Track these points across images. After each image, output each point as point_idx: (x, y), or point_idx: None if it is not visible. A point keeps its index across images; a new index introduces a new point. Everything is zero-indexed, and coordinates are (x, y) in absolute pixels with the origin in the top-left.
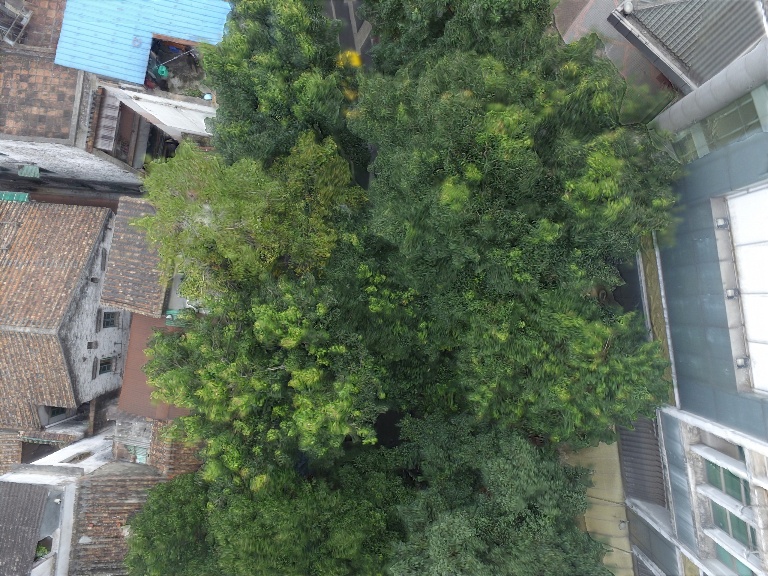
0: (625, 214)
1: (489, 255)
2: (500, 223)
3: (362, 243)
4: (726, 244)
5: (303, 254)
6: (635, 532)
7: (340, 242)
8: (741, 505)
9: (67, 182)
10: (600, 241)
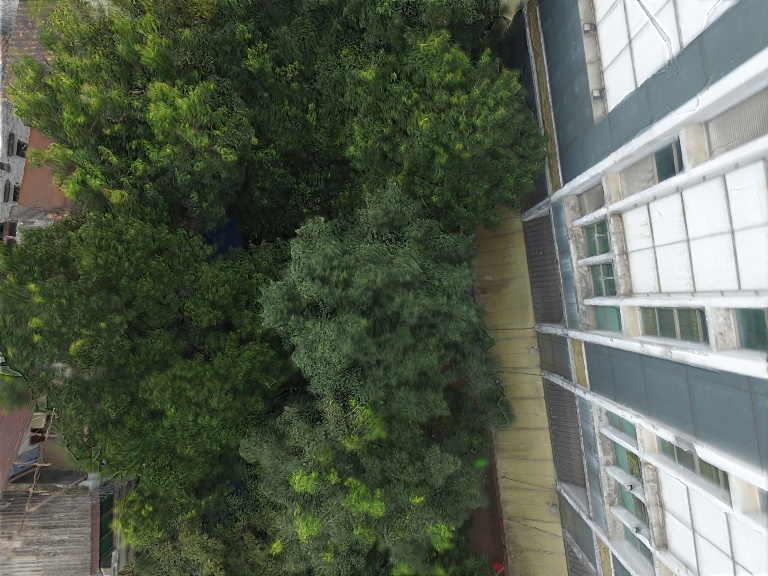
0: None
1: None
2: None
3: (242, 7)
4: None
5: (182, 14)
6: (544, 356)
7: (222, 9)
8: None
9: None
10: None
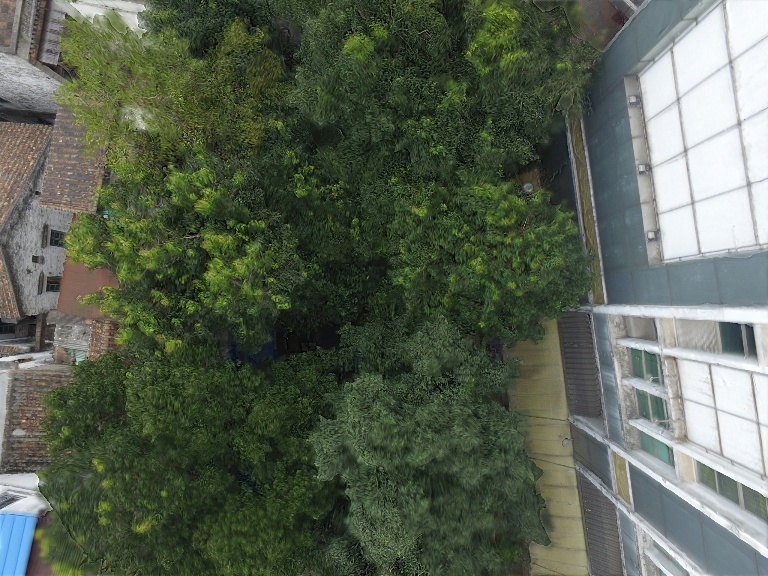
0: (526, 71)
1: (404, 127)
2: (413, 94)
3: (289, 131)
4: (639, 122)
5: (230, 140)
6: (577, 448)
7: (268, 132)
8: (658, 385)
9: (23, 115)
10: (509, 108)
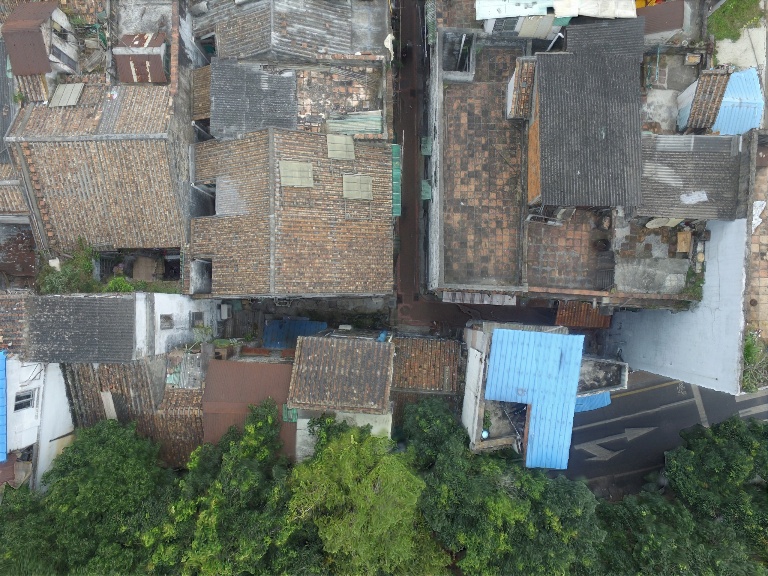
0: None
1: None
2: None
3: None
4: None
5: None
6: None
7: None
8: None
9: None
10: None
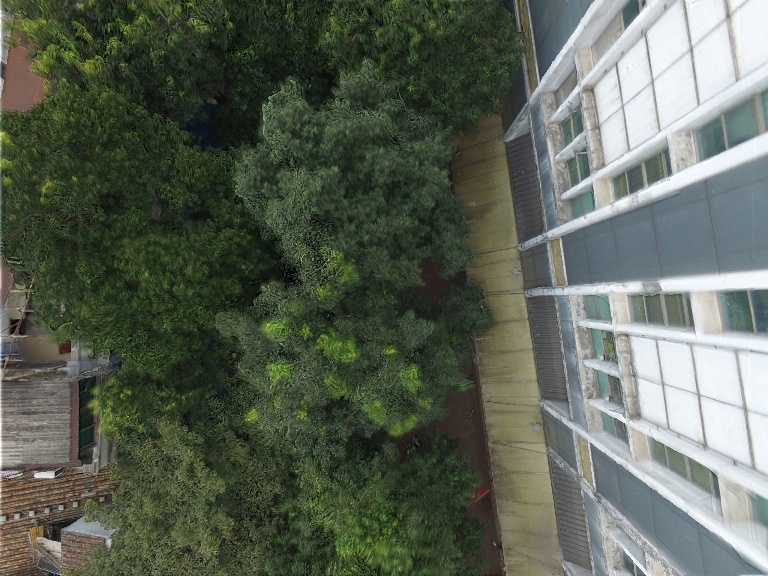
0: None
1: None
2: None
3: None
4: None
5: None
6: (526, 275)
7: None
8: None
9: None
10: None
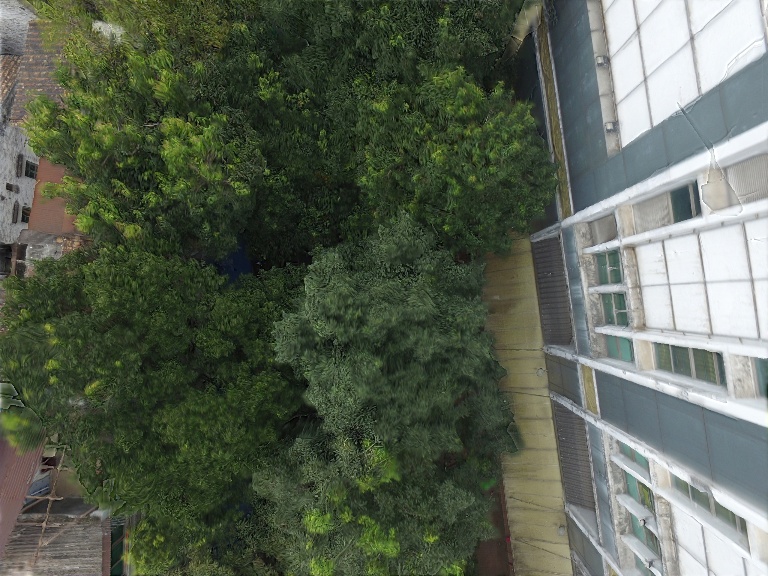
0: None
1: (363, 18)
2: None
3: (254, 36)
4: (597, 15)
5: (194, 43)
6: (552, 377)
7: (233, 37)
8: None
9: None
10: None
